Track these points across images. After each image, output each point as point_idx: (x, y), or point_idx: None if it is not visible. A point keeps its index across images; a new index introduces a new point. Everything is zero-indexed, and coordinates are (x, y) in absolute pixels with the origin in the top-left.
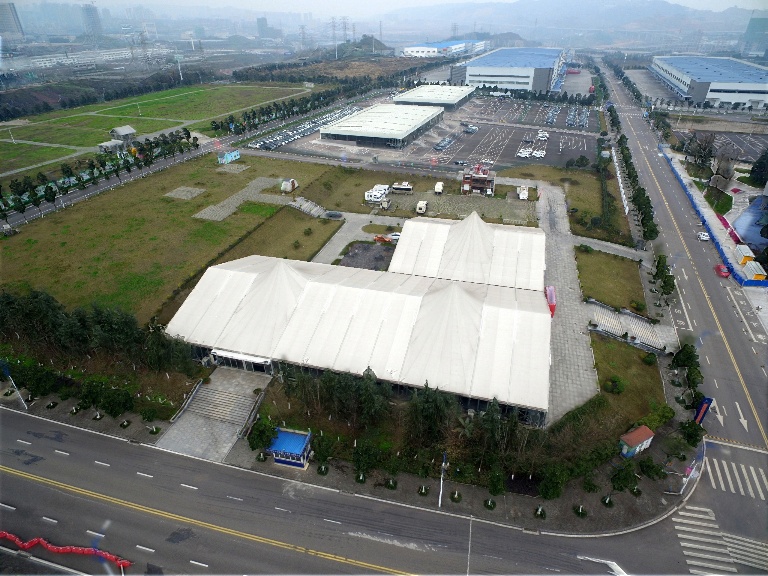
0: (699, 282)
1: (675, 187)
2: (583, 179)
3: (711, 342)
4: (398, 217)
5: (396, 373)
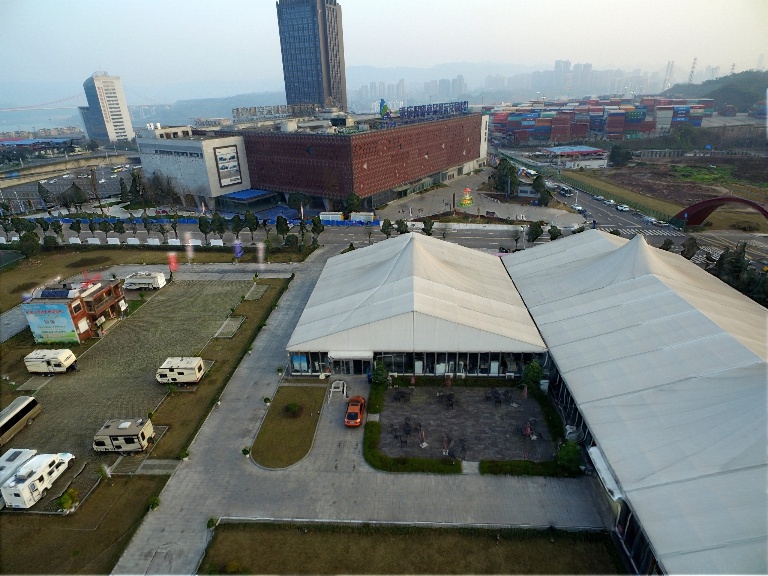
0: (378, 235)
1: (141, 226)
2: (80, 257)
3: (470, 240)
4: (209, 412)
5: (761, 307)
